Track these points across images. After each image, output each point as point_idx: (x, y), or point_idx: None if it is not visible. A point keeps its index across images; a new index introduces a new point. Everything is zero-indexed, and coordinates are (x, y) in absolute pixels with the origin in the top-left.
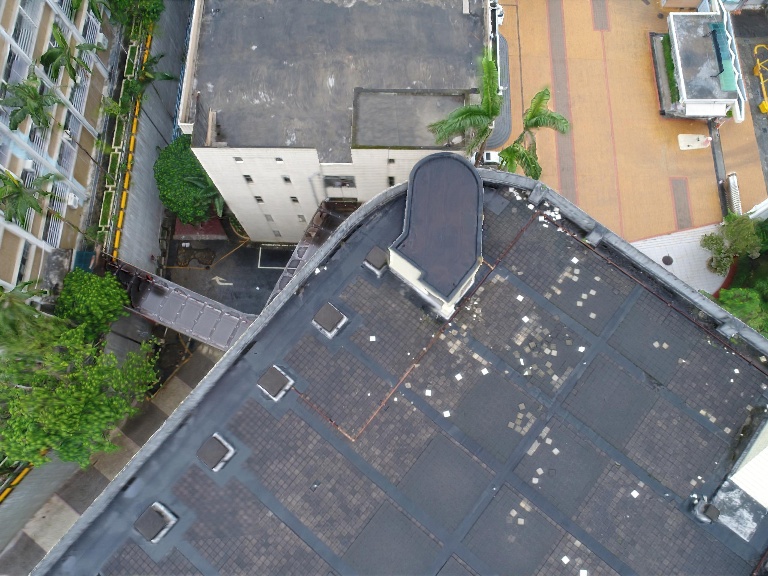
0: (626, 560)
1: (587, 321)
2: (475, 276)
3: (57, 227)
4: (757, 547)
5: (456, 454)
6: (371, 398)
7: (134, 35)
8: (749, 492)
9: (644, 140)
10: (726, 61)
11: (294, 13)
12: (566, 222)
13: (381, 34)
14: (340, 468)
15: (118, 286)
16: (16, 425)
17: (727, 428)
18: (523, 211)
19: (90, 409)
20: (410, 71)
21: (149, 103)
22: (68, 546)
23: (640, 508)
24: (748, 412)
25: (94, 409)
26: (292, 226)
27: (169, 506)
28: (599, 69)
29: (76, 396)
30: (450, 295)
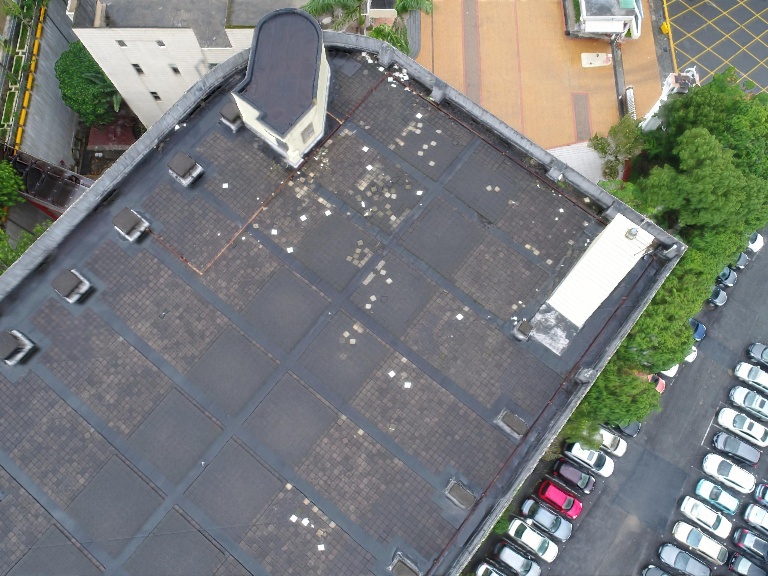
0: (447, 373)
1: (426, 168)
2: (325, 130)
3: None
4: (569, 361)
5: (296, 284)
6: (221, 237)
7: None
8: (564, 313)
9: (548, 58)
10: None
11: None
12: (413, 82)
13: None
14: (188, 298)
15: (13, 172)
16: None
17: (549, 260)
18: (374, 73)
19: None
20: None
21: (57, 12)
22: None
23: (464, 329)
24: (569, 246)
25: None
26: None
27: (27, 334)
28: None
29: None
30: (285, 132)
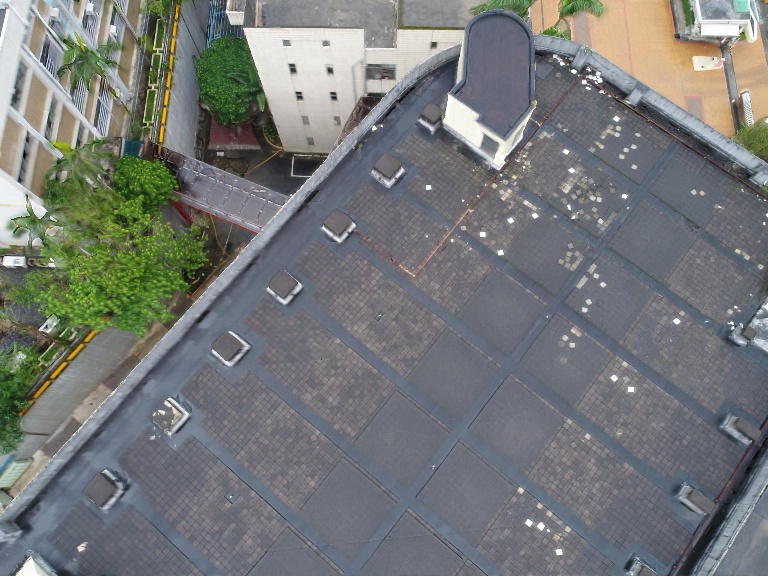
0: (670, 378)
1: (629, 172)
2: (523, 133)
3: (105, 118)
4: None
5: (510, 287)
6: (429, 239)
7: None
8: None
9: (660, 61)
10: None
11: None
12: (607, 85)
13: None
14: (402, 301)
15: (167, 172)
16: (79, 288)
17: (760, 265)
18: (567, 75)
19: (148, 278)
20: None
21: (186, 11)
22: (148, 370)
23: (682, 333)
24: None
25: (151, 278)
26: (326, 131)
27: (242, 335)
28: None
29: (137, 261)
30: (507, 134)
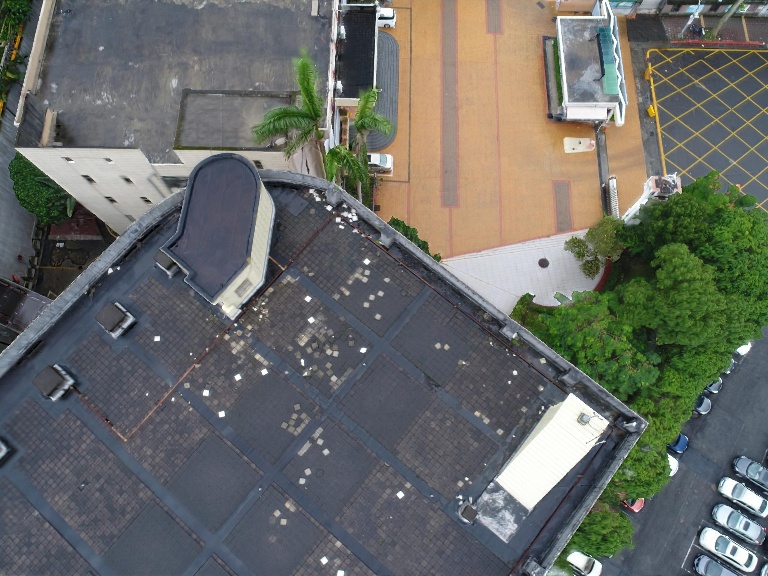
0: (384, 561)
1: (372, 322)
2: (266, 277)
3: None
4: (517, 548)
5: (226, 454)
6: (149, 398)
7: (3, 35)
8: (513, 493)
9: (529, 143)
10: (610, 65)
11: (144, 14)
12: (362, 223)
13: (228, 36)
14: (110, 468)
15: None
16: None
17: (500, 430)
18: (321, 212)
19: None
20: (254, 73)
21: None
22: None
23: (404, 509)
24: (522, 414)
25: None
26: None
27: None
28: (489, 72)
29: None
30: (215, 295)
